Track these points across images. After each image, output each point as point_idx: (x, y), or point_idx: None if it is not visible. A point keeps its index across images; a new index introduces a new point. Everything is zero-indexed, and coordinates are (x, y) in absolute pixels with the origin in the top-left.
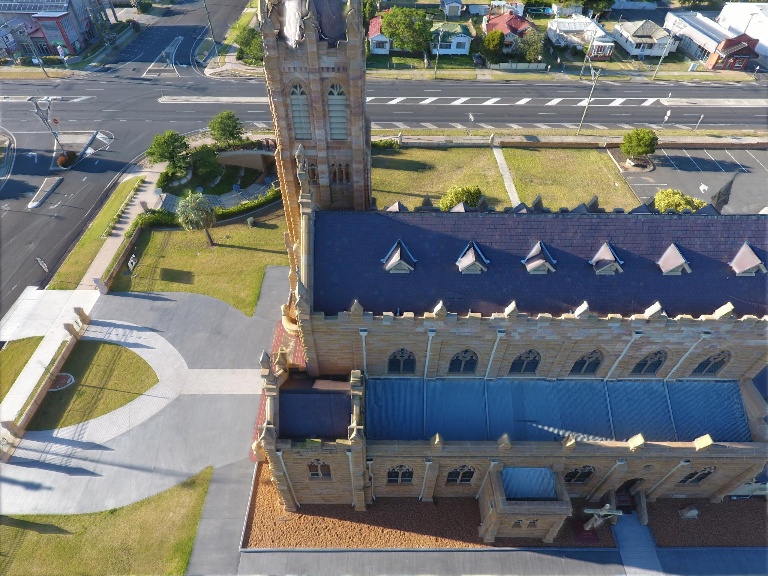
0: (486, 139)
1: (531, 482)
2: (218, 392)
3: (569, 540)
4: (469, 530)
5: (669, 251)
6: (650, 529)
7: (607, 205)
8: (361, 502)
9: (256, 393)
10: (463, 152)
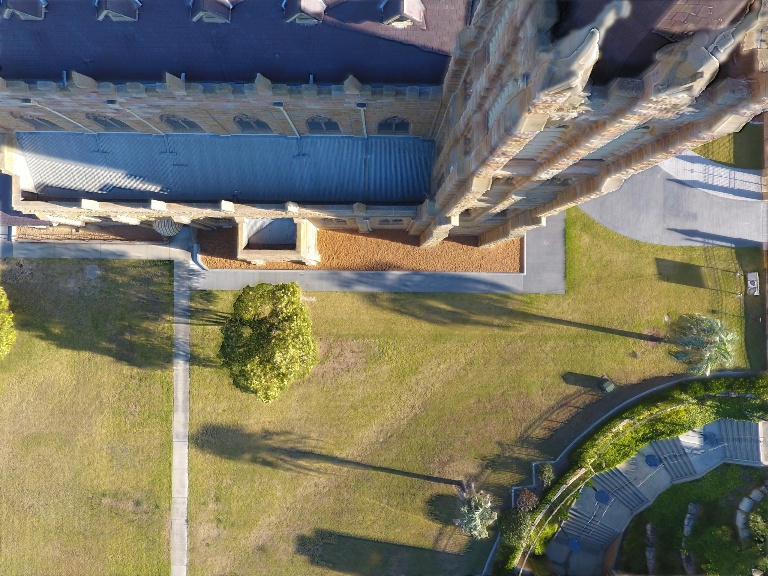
0: None
1: None
2: None
3: None
4: None
5: None
6: None
7: (28, 434)
8: None
9: None
10: None
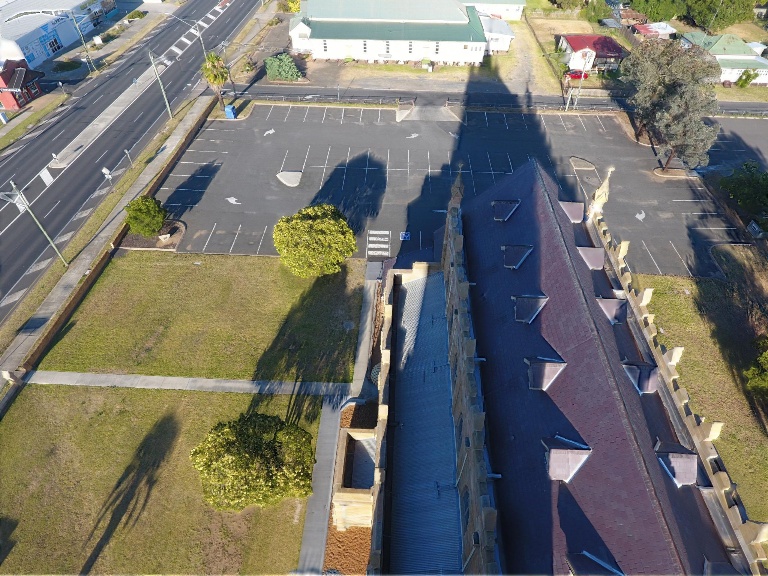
0: (3, 387)
1: None
2: None
3: None
4: None
5: (584, 254)
6: None
7: (232, 285)
8: None
9: None
10: (6, 435)
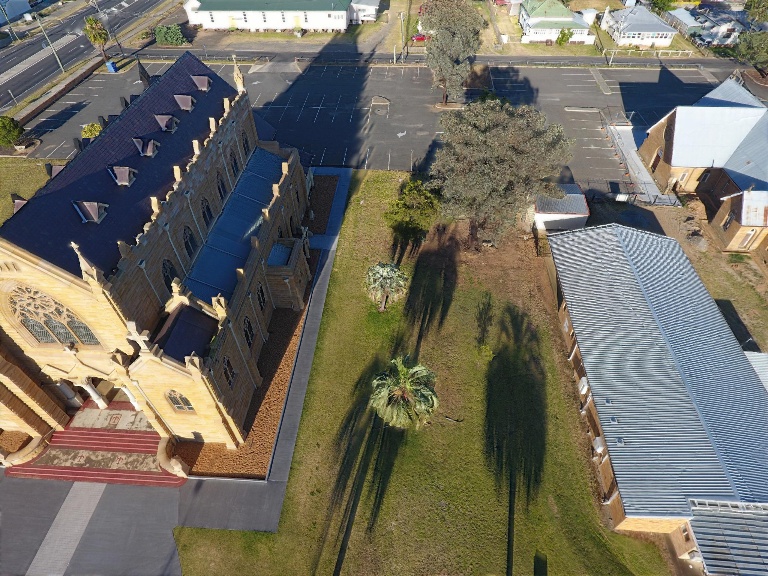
0: None
1: (279, 256)
2: (77, 541)
3: (312, 268)
4: (294, 316)
5: (178, 100)
6: (316, 234)
7: None
8: (257, 372)
9: (102, 490)
10: None
